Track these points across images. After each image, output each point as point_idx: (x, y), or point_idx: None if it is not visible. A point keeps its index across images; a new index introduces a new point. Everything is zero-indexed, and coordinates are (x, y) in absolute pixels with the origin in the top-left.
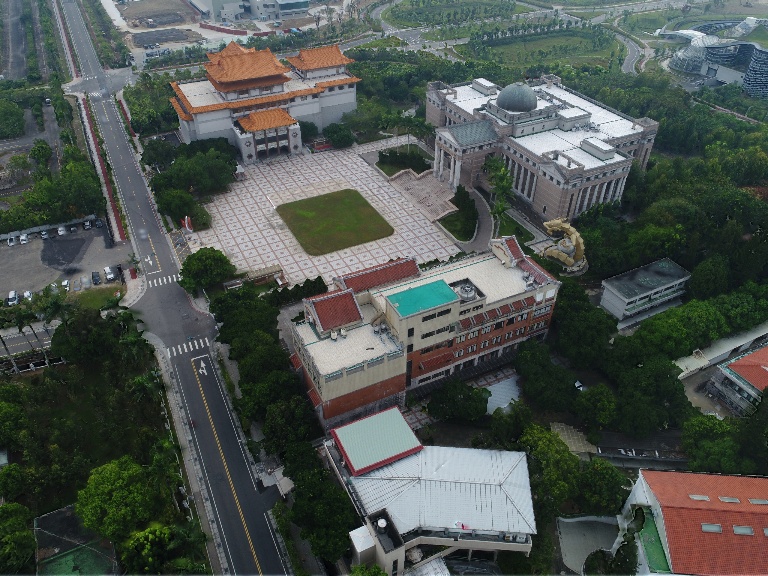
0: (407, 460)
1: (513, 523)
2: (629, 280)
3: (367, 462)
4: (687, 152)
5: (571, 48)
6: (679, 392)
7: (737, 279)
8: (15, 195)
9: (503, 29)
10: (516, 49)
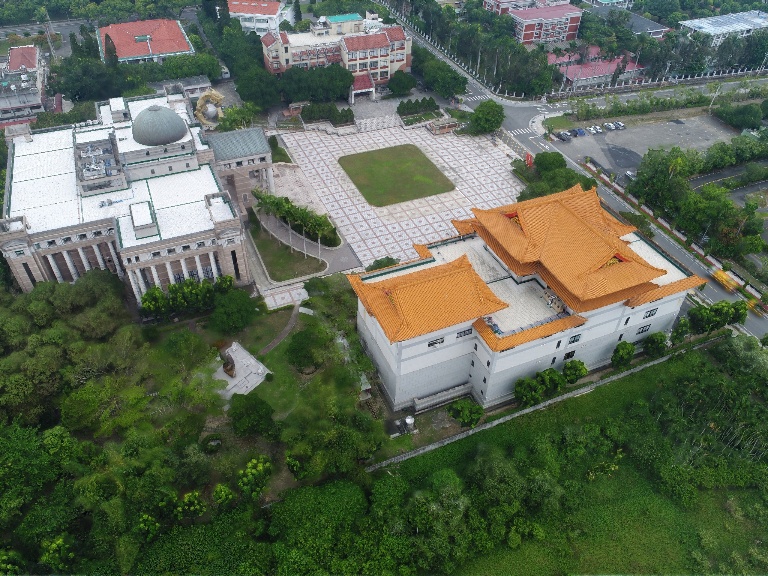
0: None
1: None
2: (192, 84)
3: None
4: None
5: None
6: None
7: None
8: None
9: None
10: None
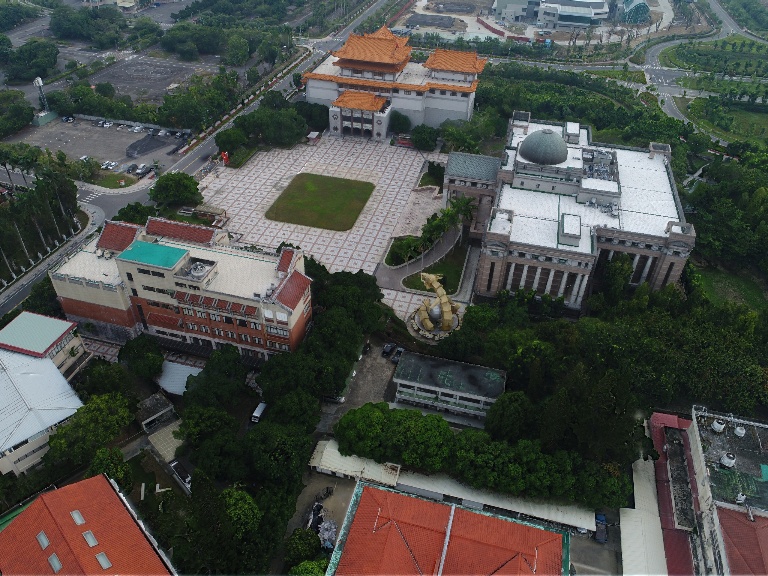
0: (25, 357)
1: None
2: (430, 366)
3: (3, 340)
4: None
5: None
6: (261, 462)
7: None
8: None
9: None
10: None
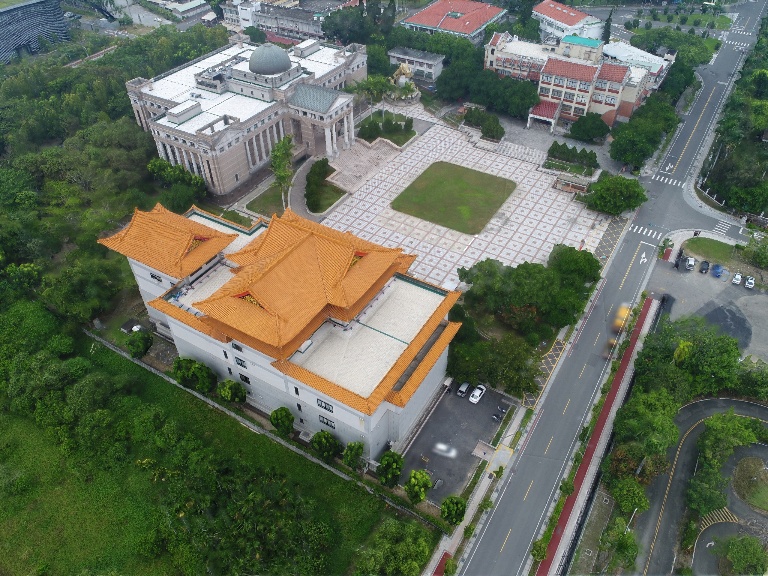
0: None
1: None
2: (424, 58)
3: (655, 64)
4: None
5: None
6: None
7: None
8: (760, 516)
9: None
10: None
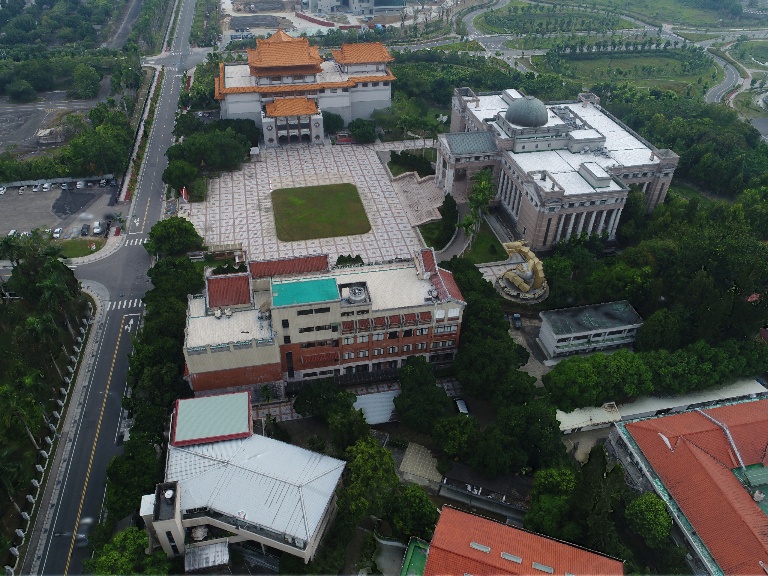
0: (230, 443)
1: (293, 526)
2: (570, 316)
3: (190, 436)
4: (729, 194)
5: (656, 70)
6: (545, 439)
7: (693, 336)
8: None
9: (589, 43)
10: (598, 65)
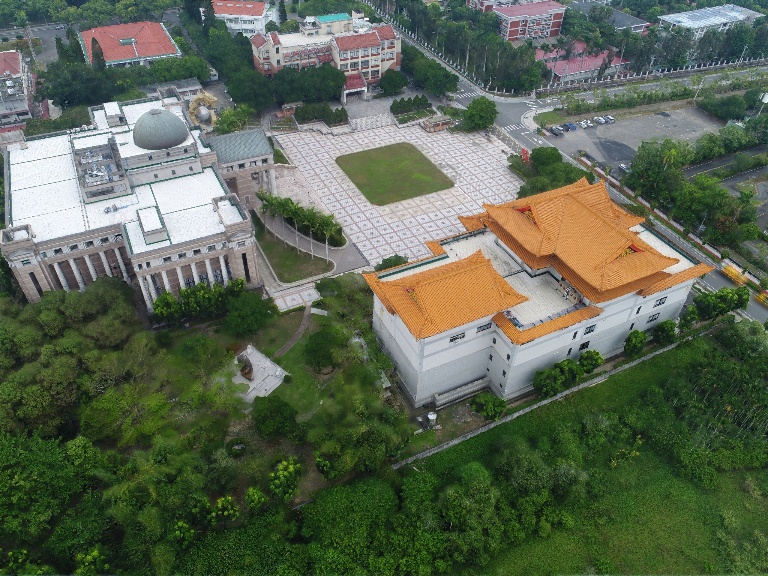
0: None
1: None
2: (182, 87)
3: None
4: None
5: None
6: None
7: None
8: None
9: None
10: None
